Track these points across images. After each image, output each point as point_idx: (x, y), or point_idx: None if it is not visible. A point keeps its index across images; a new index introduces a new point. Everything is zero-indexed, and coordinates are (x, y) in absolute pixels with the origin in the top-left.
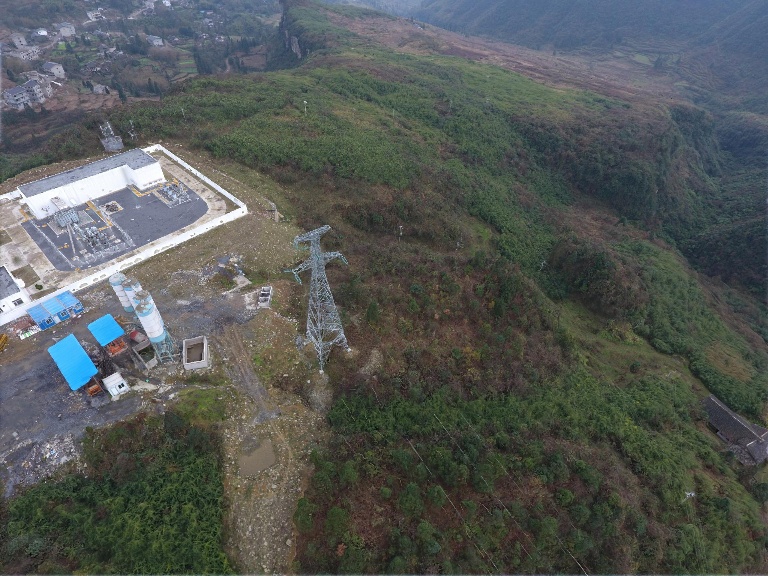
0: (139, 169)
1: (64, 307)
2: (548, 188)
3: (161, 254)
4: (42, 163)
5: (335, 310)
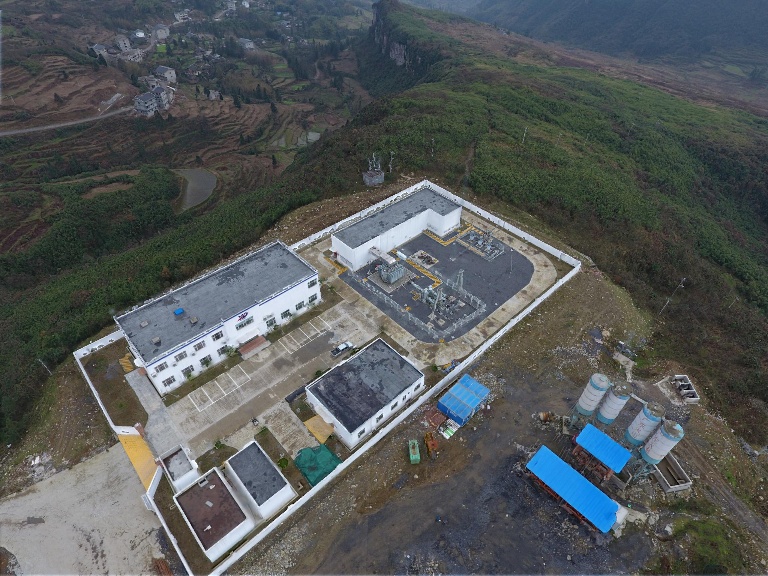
0: (447, 215)
1: (480, 398)
2: (738, 221)
3: (520, 323)
4: (311, 199)
5: None
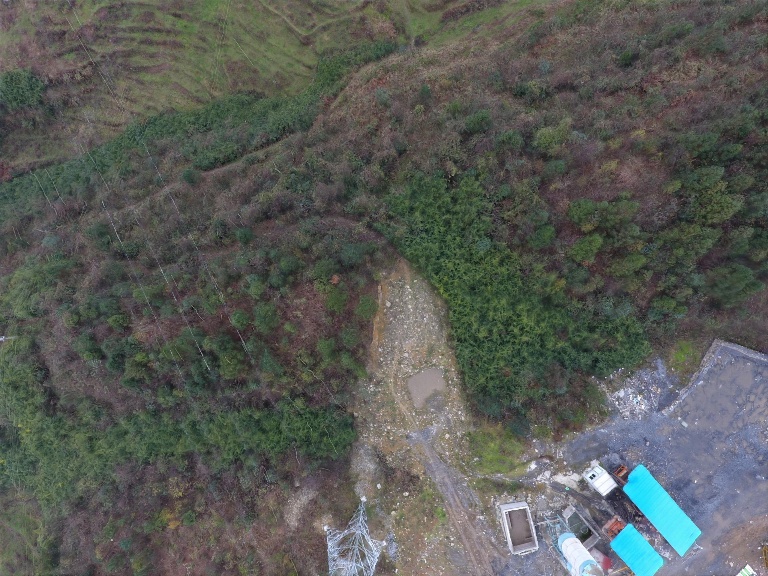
0: None
1: None
2: None
3: None
4: None
5: (332, 573)
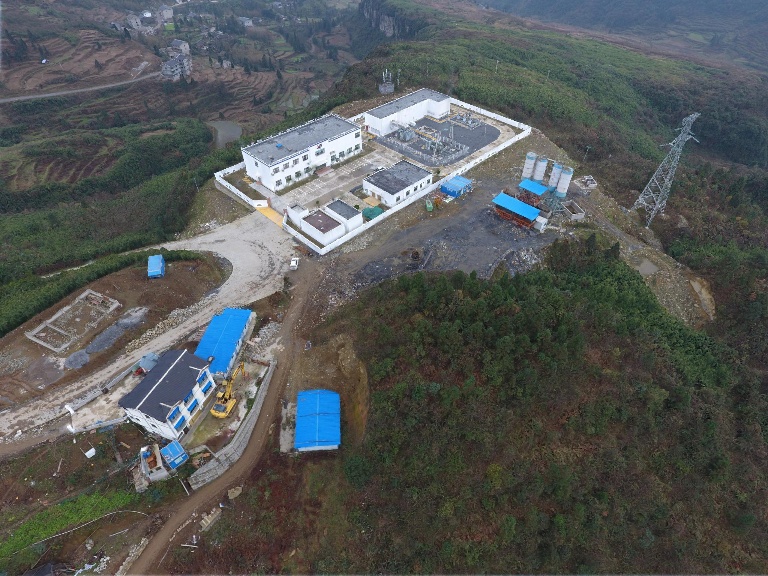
0: (441, 102)
1: (466, 183)
2: None
3: (491, 158)
4: (344, 101)
5: None
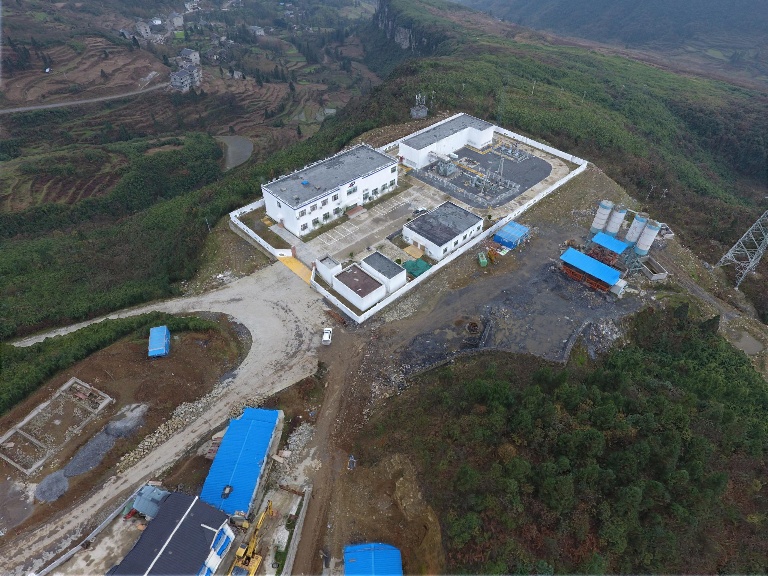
0: (484, 130)
1: (523, 232)
2: (714, 168)
3: (545, 198)
4: (373, 127)
5: None
